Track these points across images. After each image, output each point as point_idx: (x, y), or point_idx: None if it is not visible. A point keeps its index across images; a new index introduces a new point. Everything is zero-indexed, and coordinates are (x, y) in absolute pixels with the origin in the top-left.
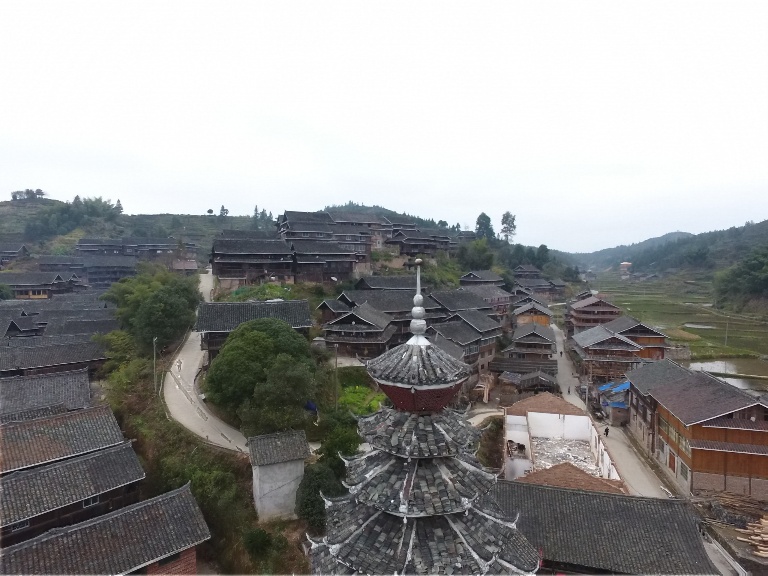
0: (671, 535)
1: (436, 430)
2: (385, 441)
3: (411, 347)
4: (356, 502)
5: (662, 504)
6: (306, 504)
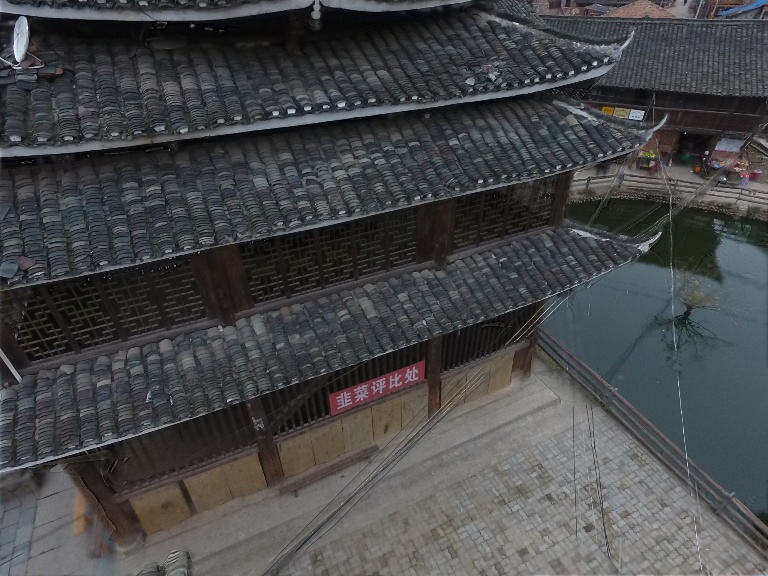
0: (757, 56)
1: None
2: None
3: None
4: None
5: (761, 26)
6: None
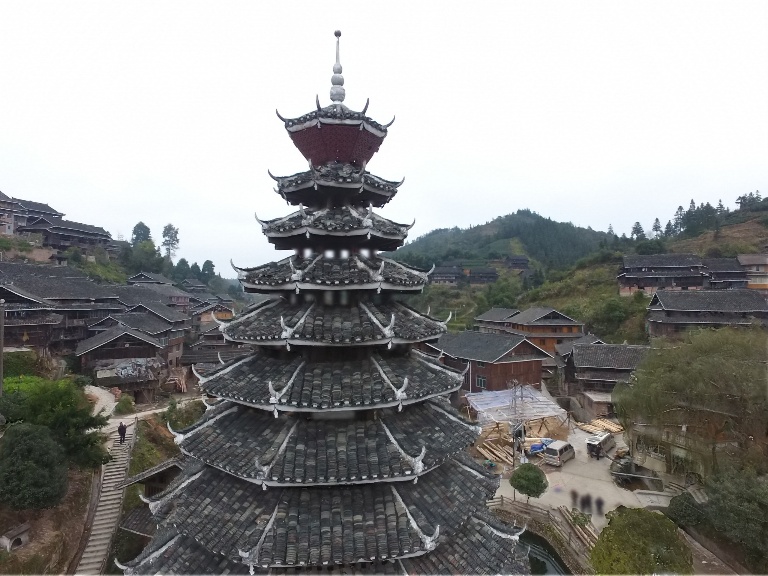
0: None
1: (370, 177)
2: (333, 176)
3: (339, 105)
4: (307, 237)
5: None
6: (7, 479)
